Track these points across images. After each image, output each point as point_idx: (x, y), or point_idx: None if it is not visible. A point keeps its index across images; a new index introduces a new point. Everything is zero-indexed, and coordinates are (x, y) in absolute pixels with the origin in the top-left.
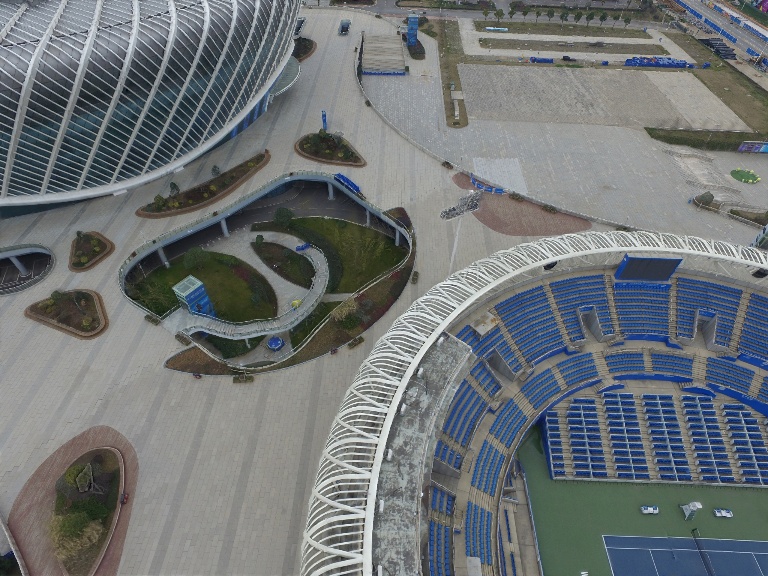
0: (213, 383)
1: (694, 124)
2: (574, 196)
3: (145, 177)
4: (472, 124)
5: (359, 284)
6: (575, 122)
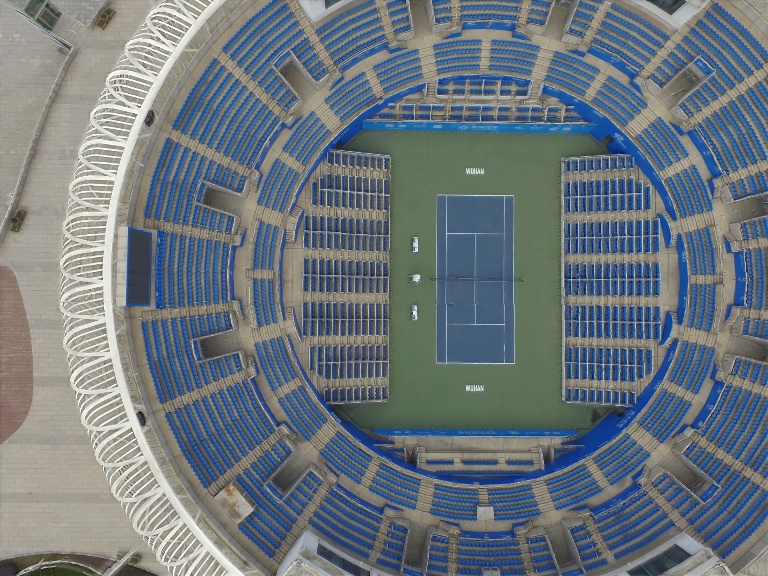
0: None
1: None
2: None
3: None
4: None
5: None
6: None
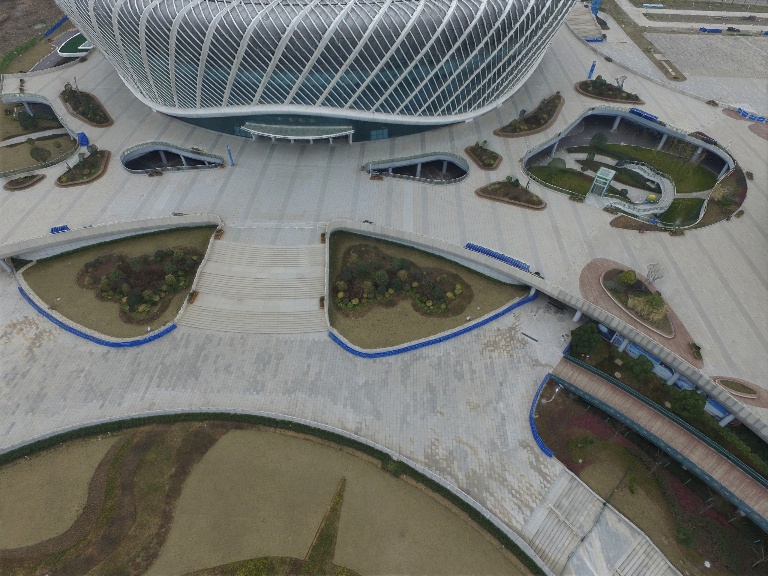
0: (656, 236)
1: None
2: None
3: (485, 109)
4: (690, 78)
5: (684, 187)
6: None
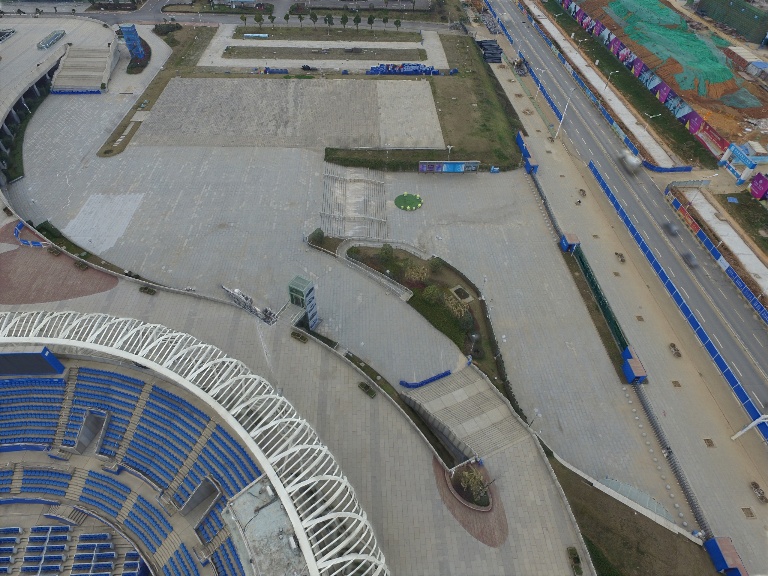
0: None
1: (385, 142)
2: (173, 239)
3: None
4: (126, 152)
5: None
6: (250, 144)
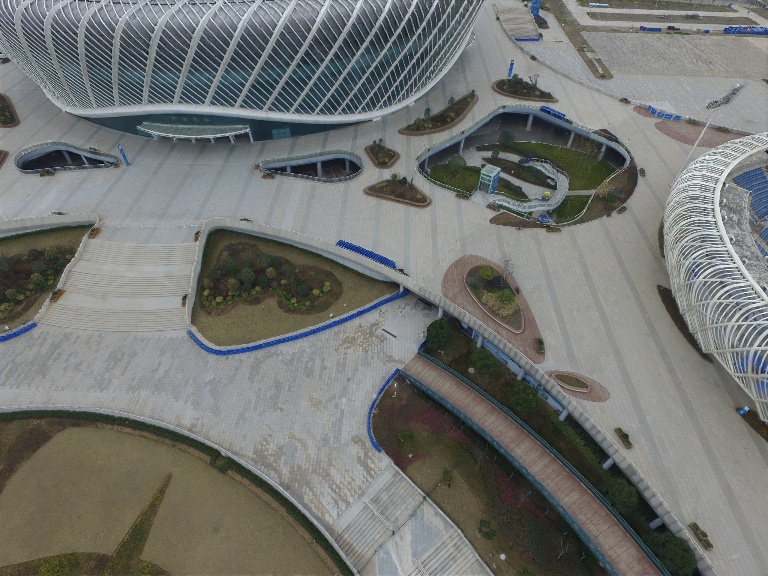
0: (532, 232)
1: None
2: None
3: (394, 107)
4: (617, 77)
5: (584, 184)
6: (702, 75)
